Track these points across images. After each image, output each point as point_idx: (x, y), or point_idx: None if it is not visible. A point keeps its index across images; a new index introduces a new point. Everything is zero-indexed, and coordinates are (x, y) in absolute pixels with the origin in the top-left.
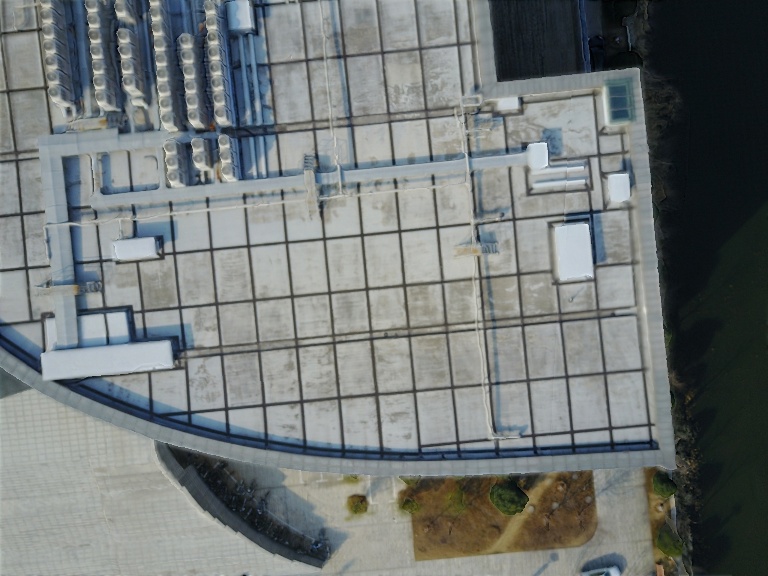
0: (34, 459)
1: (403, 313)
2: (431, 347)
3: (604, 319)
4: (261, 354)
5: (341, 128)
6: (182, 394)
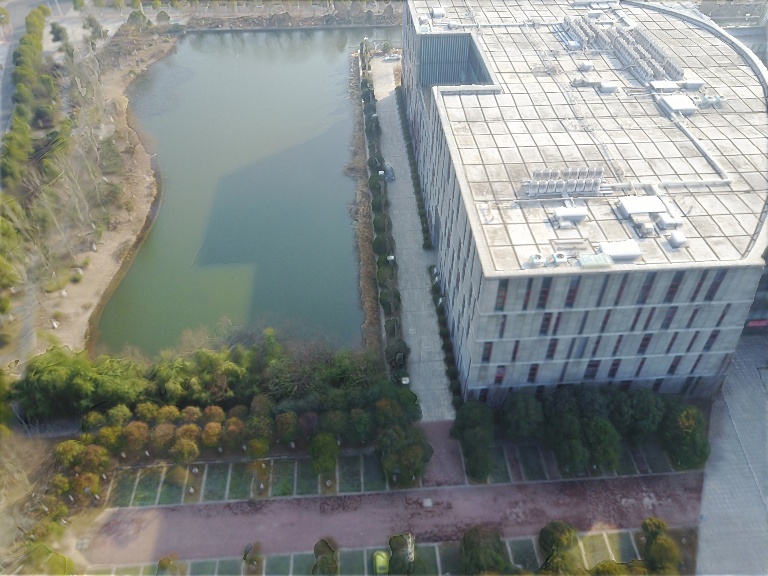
0: None
1: (496, 8)
2: (485, 4)
3: (426, 7)
4: (544, 4)
5: None
6: None
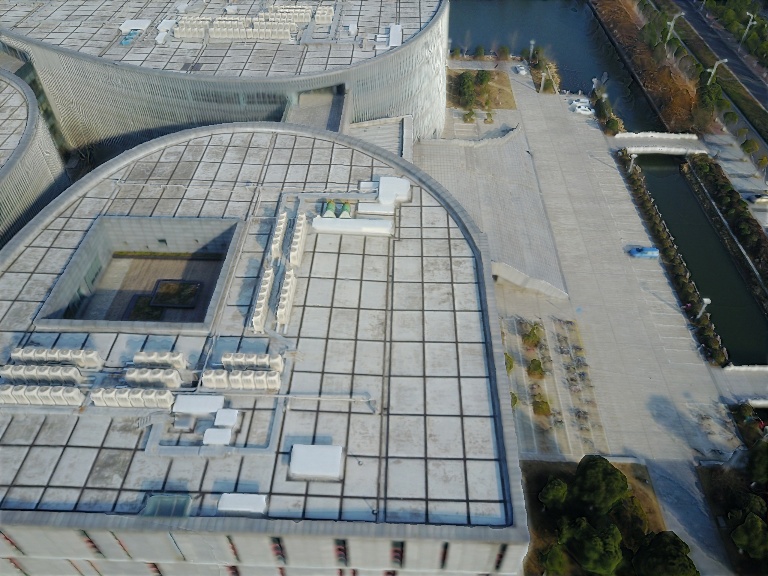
0: (454, 184)
1: None
2: None
3: None
4: (401, 17)
5: (322, 2)
6: (413, 29)
